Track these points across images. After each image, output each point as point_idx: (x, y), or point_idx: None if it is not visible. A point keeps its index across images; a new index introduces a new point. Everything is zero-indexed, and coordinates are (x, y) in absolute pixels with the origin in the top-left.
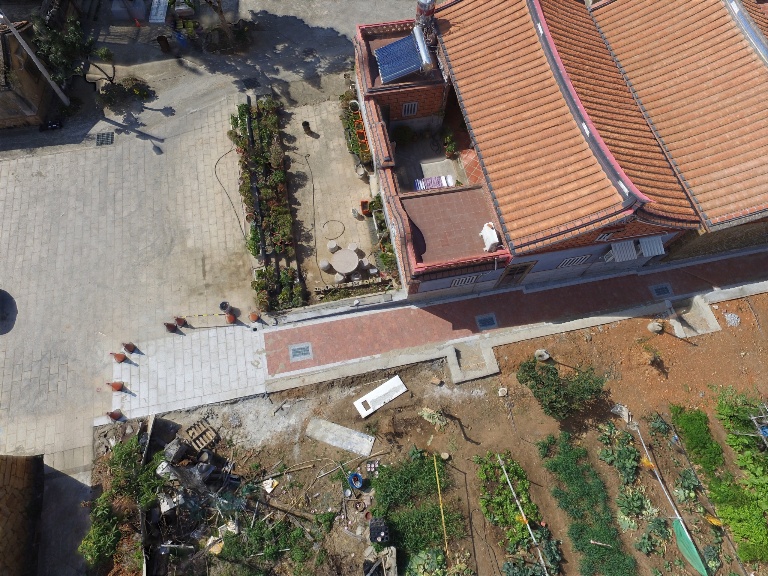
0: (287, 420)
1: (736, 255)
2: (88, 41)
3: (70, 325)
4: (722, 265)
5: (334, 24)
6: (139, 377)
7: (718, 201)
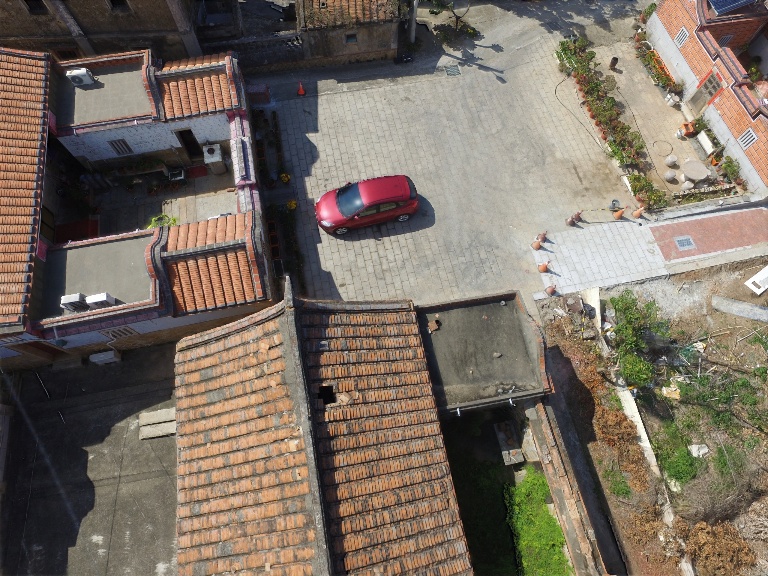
0: (691, 297)
1: None
2: None
3: (483, 220)
4: None
5: None
6: (558, 261)
7: None
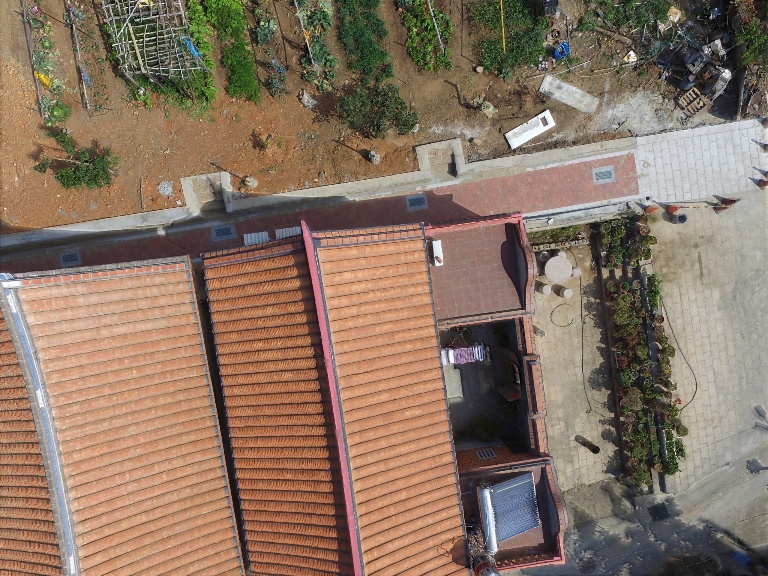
0: (615, 114)
1: None
2: None
3: None
4: None
5: None
6: (751, 157)
7: (170, 290)
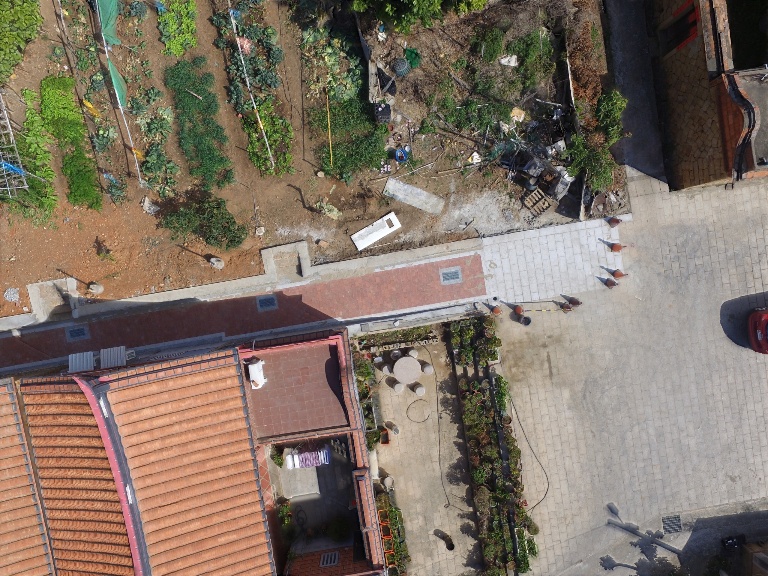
0: (462, 214)
1: None
2: None
3: (669, 308)
4: (3, 361)
5: None
6: (598, 256)
7: None
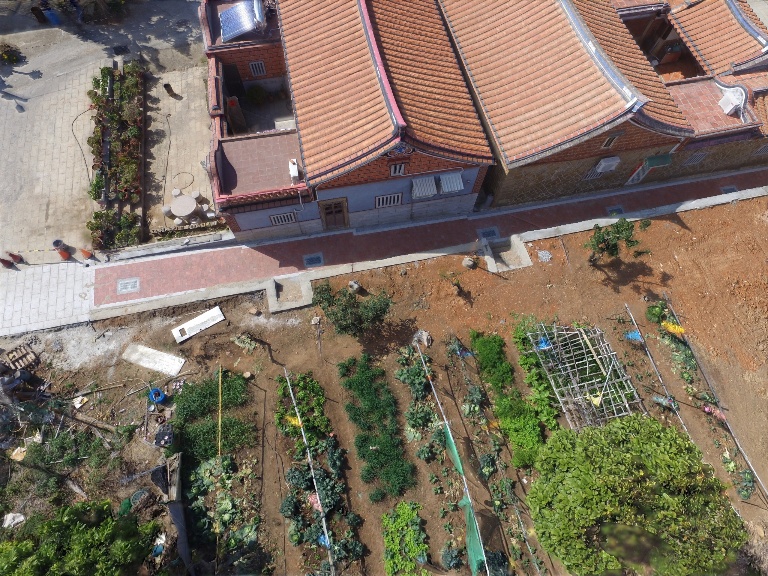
0: (107, 346)
1: (566, 202)
2: None
3: None
4: (551, 211)
5: None
6: None
7: (517, 141)
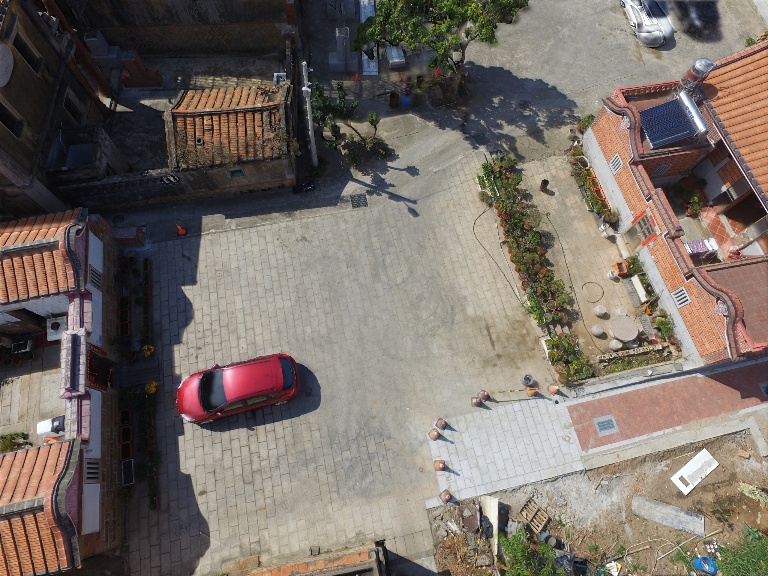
0: (609, 498)
1: None
2: (354, 105)
3: (376, 400)
4: None
5: (542, 75)
6: (458, 455)
7: None
